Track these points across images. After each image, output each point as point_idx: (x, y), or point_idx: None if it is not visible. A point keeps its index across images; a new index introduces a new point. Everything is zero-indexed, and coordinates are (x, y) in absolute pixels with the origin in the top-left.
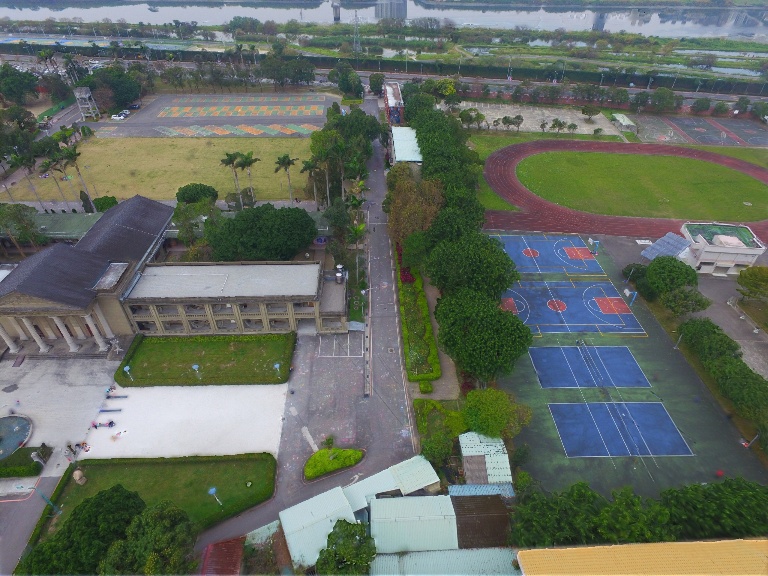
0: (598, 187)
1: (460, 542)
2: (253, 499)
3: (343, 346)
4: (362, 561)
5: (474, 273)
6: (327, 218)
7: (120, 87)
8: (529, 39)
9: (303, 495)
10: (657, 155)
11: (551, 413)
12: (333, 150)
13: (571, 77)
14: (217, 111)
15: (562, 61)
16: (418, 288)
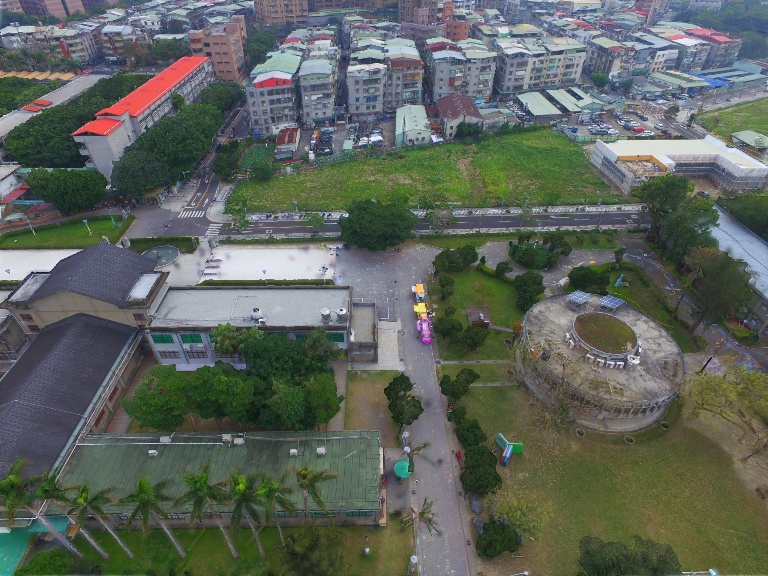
0: None
1: None
2: (14, 231)
3: None
4: None
5: None
6: None
7: None
8: None
9: None
10: None
11: None
12: None
13: None
14: None
15: None
16: None
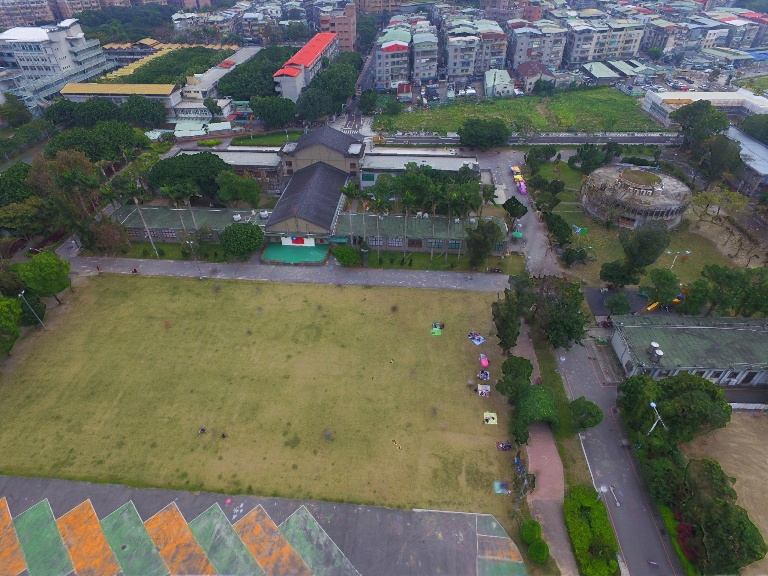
0: None
1: None
2: None
3: None
4: None
5: None
6: None
7: None
8: None
9: (224, 140)
10: None
11: None
12: None
13: None
14: None
15: None
16: None
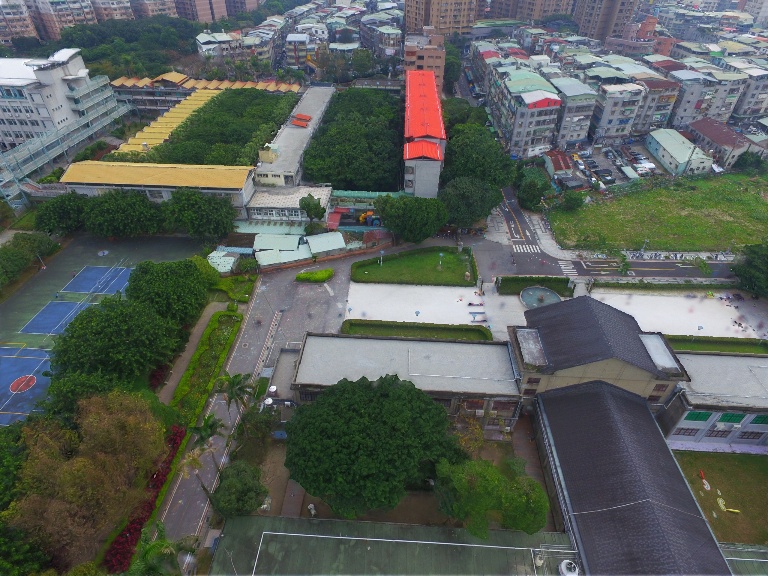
0: None
1: None
2: (362, 262)
3: None
4: None
5: None
6: None
7: None
8: None
9: (335, 267)
10: None
11: None
12: None
13: None
14: None
15: None
16: None
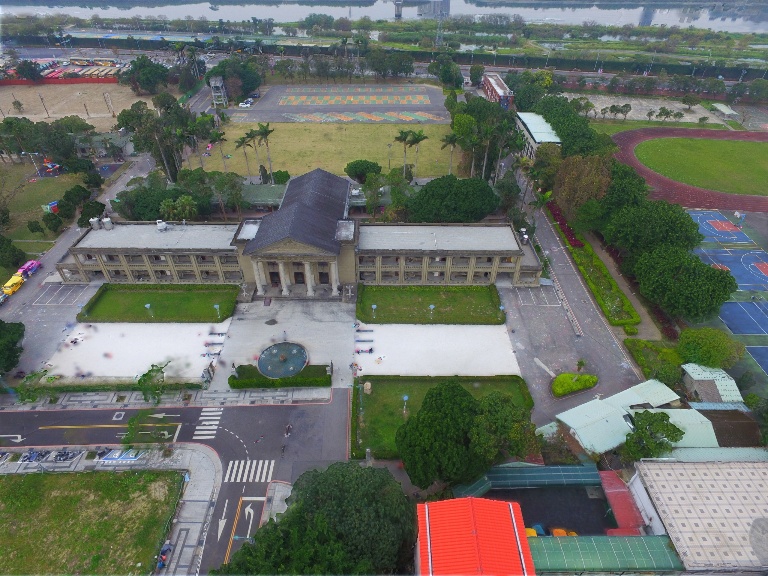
0: (720, 169)
1: (719, 442)
2: None
3: (540, 297)
4: (677, 438)
5: (668, 232)
6: (498, 189)
7: (247, 77)
8: (598, 34)
9: (558, 408)
10: (767, 142)
11: (749, 353)
12: (497, 129)
13: (659, 70)
14: (332, 100)
15: (640, 55)
16: (590, 251)
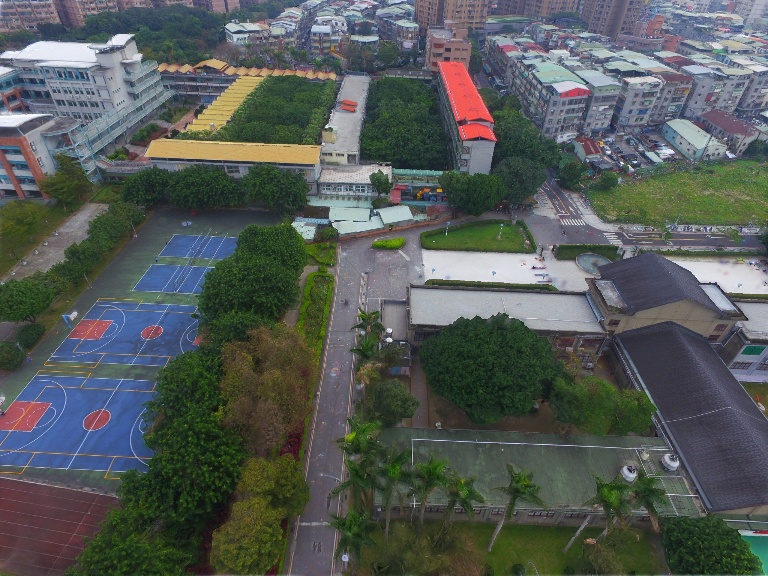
0: None
1: None
2: (429, 232)
3: None
4: None
5: None
6: None
7: None
8: None
9: (404, 236)
10: None
11: None
12: None
13: None
14: None
15: None
16: None
